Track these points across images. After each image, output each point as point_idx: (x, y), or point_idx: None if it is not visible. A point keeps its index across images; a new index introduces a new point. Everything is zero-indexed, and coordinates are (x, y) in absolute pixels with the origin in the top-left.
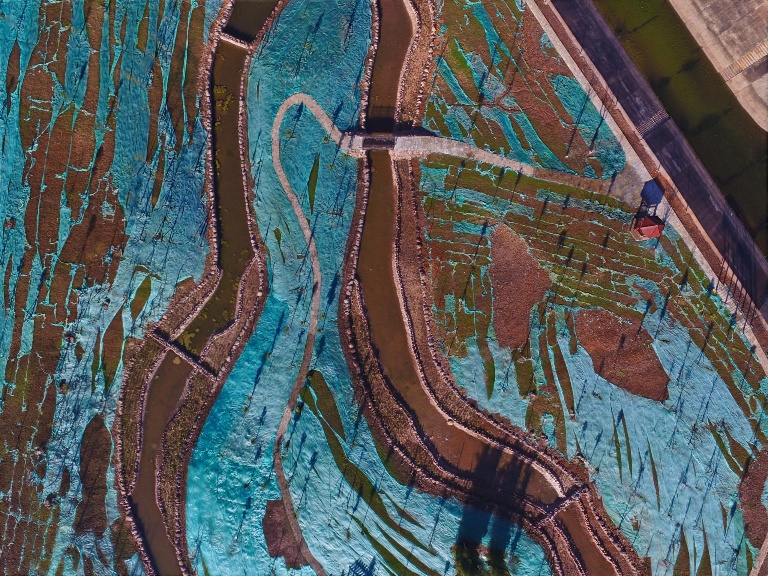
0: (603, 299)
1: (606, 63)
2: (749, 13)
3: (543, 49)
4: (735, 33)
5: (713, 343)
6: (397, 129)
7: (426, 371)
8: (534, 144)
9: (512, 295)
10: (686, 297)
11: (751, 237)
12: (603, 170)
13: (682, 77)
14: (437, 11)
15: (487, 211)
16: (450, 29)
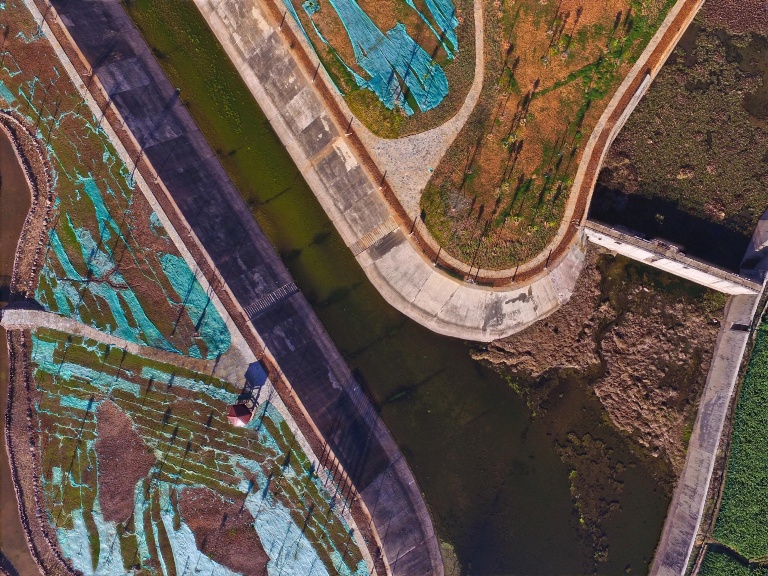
0: (206, 477)
1: (222, 240)
2: (364, 196)
3: (152, 228)
4: (356, 213)
5: (313, 524)
6: (11, 299)
7: (36, 540)
8: (141, 322)
9: (117, 470)
10: (288, 478)
11: (375, 411)
12: (208, 351)
13: (313, 250)
14: (53, 183)
15: (93, 387)
16: (62, 203)
